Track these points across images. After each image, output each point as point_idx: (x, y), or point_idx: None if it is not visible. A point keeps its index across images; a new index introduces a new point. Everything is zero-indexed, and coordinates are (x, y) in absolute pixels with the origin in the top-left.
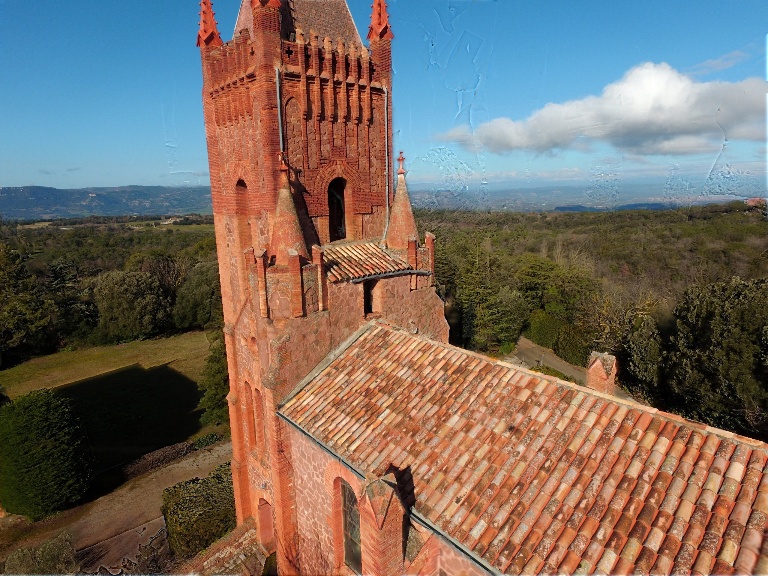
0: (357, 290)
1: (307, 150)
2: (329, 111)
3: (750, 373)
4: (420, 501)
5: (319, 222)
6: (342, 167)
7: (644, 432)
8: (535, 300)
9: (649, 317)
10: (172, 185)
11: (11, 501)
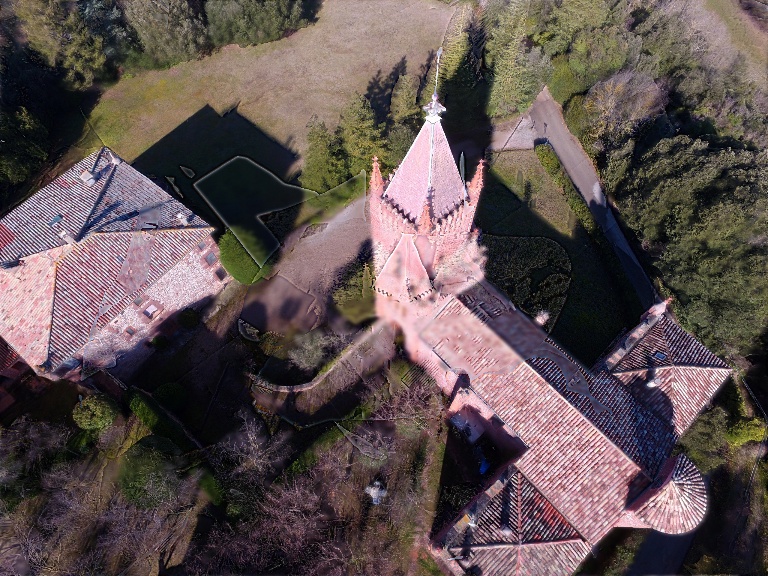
0: None
1: None
2: None
3: (656, 225)
4: (472, 385)
5: None
6: None
7: (534, 381)
8: (564, 43)
9: (632, 142)
10: None
11: (243, 280)
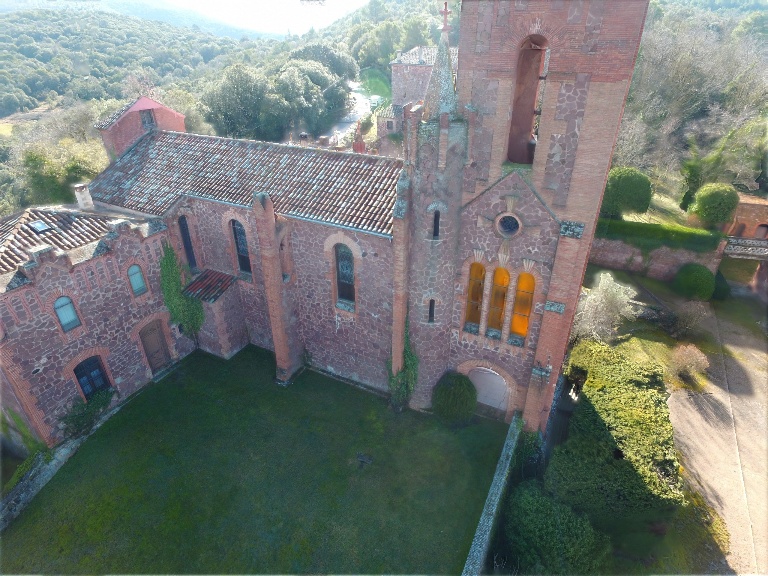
0: None
1: None
2: None
3: None
4: None
5: None
6: None
7: None
8: None
9: None
10: None
11: None
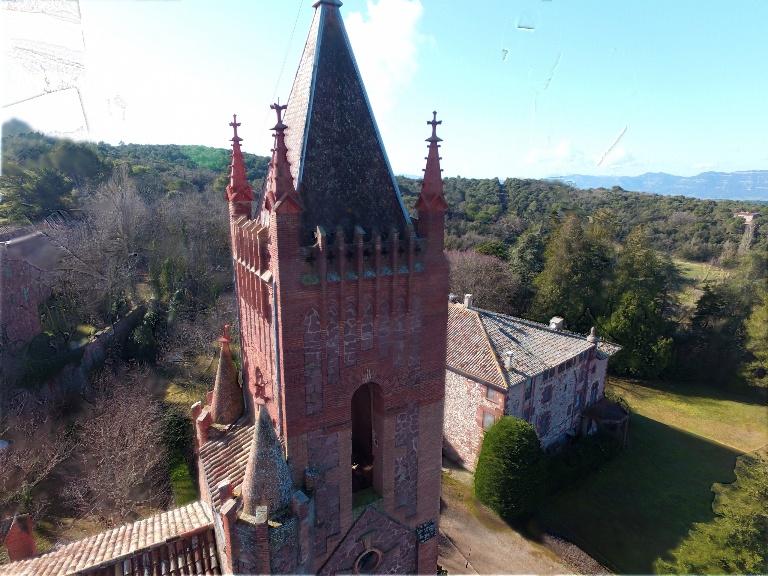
0: None
1: None
2: None
3: None
4: None
5: None
6: None
7: None
8: None
9: None
10: None
11: None
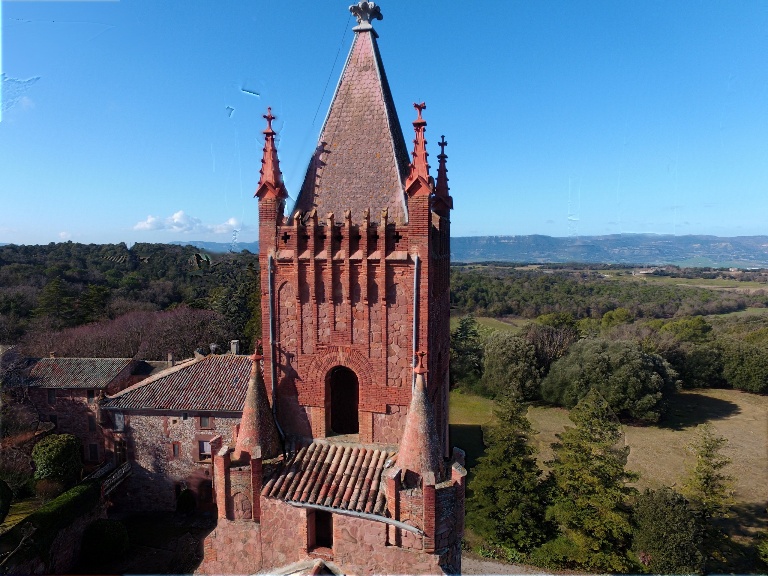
0: (298, 514)
1: (302, 334)
2: (328, 292)
3: None
4: None
5: (313, 412)
6: (346, 354)
7: None
8: None
9: None
10: (568, 257)
11: None
